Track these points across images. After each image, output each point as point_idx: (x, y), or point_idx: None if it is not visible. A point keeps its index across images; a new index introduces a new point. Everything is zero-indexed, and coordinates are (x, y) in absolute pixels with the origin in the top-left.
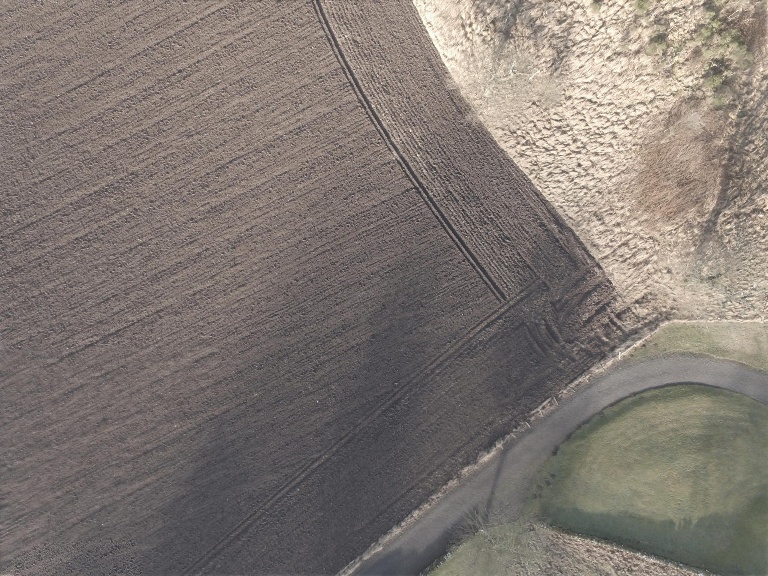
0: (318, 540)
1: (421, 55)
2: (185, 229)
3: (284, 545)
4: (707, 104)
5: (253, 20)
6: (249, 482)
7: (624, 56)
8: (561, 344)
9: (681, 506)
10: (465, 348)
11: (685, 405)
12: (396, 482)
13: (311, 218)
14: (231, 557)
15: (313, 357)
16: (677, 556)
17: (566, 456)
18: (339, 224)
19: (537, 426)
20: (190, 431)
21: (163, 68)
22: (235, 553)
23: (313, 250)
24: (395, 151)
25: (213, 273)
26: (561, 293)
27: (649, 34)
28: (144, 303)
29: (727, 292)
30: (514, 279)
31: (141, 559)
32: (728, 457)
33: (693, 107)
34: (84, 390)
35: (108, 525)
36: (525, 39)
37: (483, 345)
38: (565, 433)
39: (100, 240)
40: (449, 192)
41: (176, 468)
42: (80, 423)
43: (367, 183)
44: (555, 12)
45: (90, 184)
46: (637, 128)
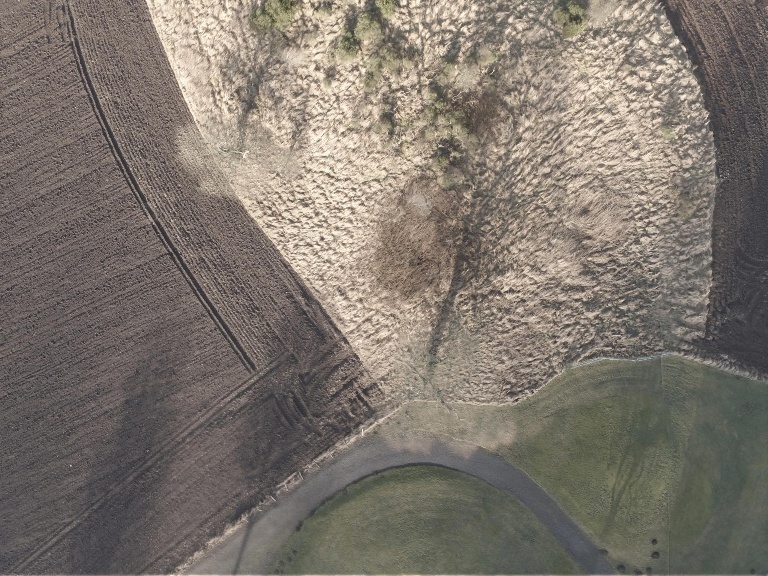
0: None
1: (177, 119)
2: None
3: None
4: (438, 184)
5: (20, 77)
6: (1, 544)
7: (355, 133)
8: (309, 418)
9: None
10: (215, 417)
11: (422, 487)
12: (145, 551)
13: (69, 280)
14: None
15: (67, 420)
16: None
17: (308, 533)
18: (96, 287)
19: (283, 500)
20: None
21: None
22: None
23: (70, 312)
24: (150, 216)
25: None
26: (309, 366)
27: (377, 112)
28: None
29: (465, 373)
30: (263, 350)
31: None
32: (457, 544)
33: (425, 186)
34: None
35: None
36: (267, 110)
37: (232, 415)
38: (310, 509)
39: None
40: (202, 259)
41: None
42: None
43: (123, 247)
44: (291, 85)
45: None
46: (373, 205)
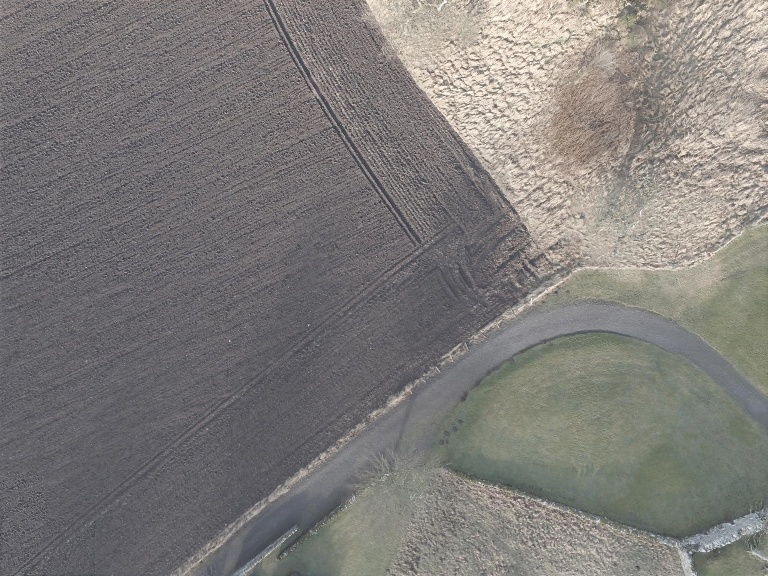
0: (225, 480)
1: None
2: (104, 163)
3: (191, 484)
4: (622, 45)
5: None
6: (158, 420)
7: None
8: (474, 289)
9: (584, 453)
10: (378, 291)
11: (594, 353)
12: (305, 424)
13: (229, 155)
14: (138, 495)
15: (227, 296)
16: (578, 503)
17: (474, 402)
18: (257, 162)
19: (447, 371)
20: (101, 367)
21: (89, 1)
22: (142, 491)
23: (230, 188)
24: (315, 89)
25: (130, 208)
26: (476, 237)
27: None
28: (61, 237)
29: None
30: (429, 222)
31: (47, 494)
32: (633, 405)
33: (608, 48)
34: None
35: (15, 458)
36: None
37: (396, 288)
38: (475, 379)
39: (20, 172)
40: (367, 132)
41: (86, 403)
42: None
43: (286, 121)
44: None
45: (12, 116)
46: (552, 69)
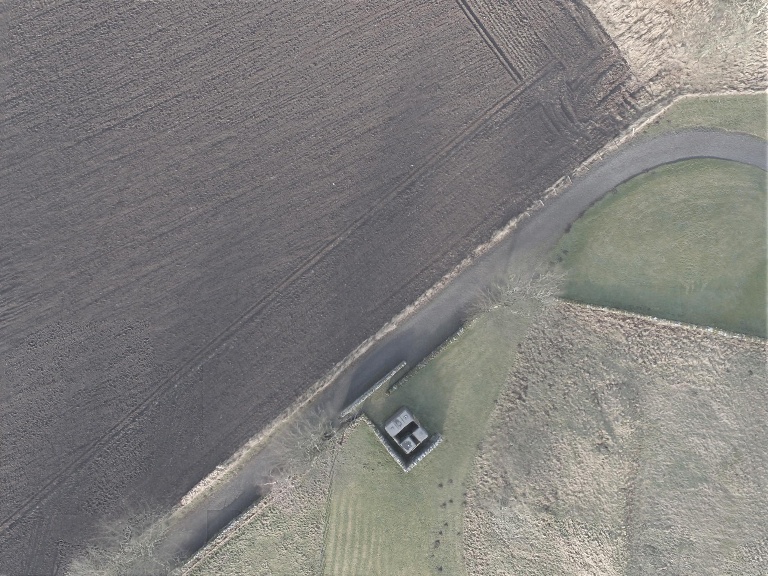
0: (332, 321)
1: None
2: (205, 15)
3: (298, 326)
4: None
5: None
6: (264, 264)
7: None
8: (576, 124)
9: (692, 271)
10: (481, 129)
11: (697, 177)
12: (410, 263)
13: (331, 2)
14: (244, 338)
15: (330, 140)
16: (687, 318)
17: (579, 232)
18: (358, 7)
19: (551, 205)
20: (206, 214)
21: None
22: (248, 334)
23: (332, 33)
24: None
25: (232, 58)
26: (577, 73)
27: None
28: (162, 88)
29: (740, 64)
30: (531, 59)
31: (154, 340)
32: (739, 222)
33: None
34: (101, 173)
35: (122, 305)
36: None
37: (499, 126)
38: (578, 211)
39: (119, 26)
40: None
41: (191, 250)
42: (96, 205)
43: None
44: None
45: None
46: None
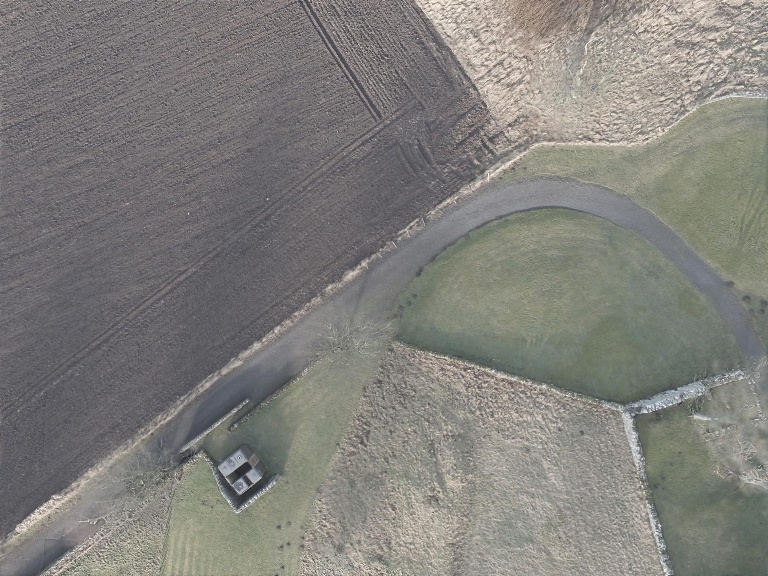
0: (178, 353)
1: None
2: (69, 35)
3: (144, 356)
4: None
5: None
6: (114, 291)
7: None
8: (433, 166)
9: (534, 324)
10: (338, 166)
11: (548, 227)
12: (261, 298)
13: (195, 28)
14: (90, 366)
15: (187, 168)
16: (526, 372)
17: (429, 276)
18: (222, 35)
19: (403, 247)
20: (59, 237)
21: None
22: (95, 362)
23: (194, 60)
24: None
25: (94, 80)
26: (436, 114)
27: None
28: (23, 107)
29: (596, 115)
30: (390, 97)
31: None
32: (584, 277)
33: None
34: None
35: None
36: None
37: (356, 163)
38: (430, 255)
39: None
40: (332, 7)
41: (42, 273)
42: None
43: None
44: None
45: None
46: None
